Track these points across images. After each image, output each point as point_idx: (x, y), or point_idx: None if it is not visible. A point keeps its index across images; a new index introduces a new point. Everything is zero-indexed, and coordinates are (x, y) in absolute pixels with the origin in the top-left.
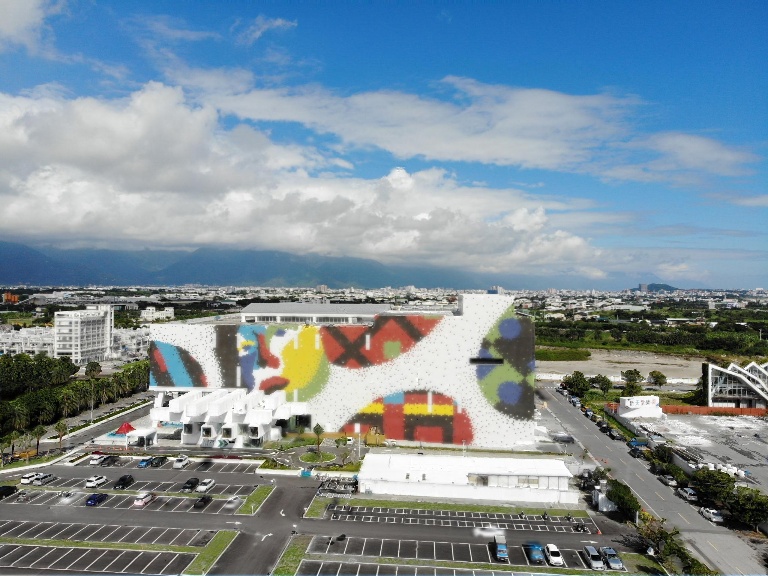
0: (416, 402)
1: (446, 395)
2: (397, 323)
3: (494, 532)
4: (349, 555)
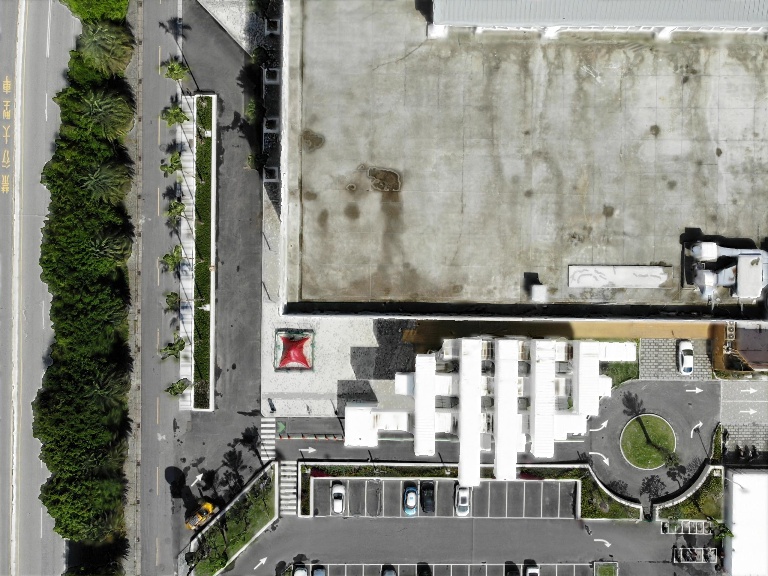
0: None
1: None
2: None
3: None
4: None
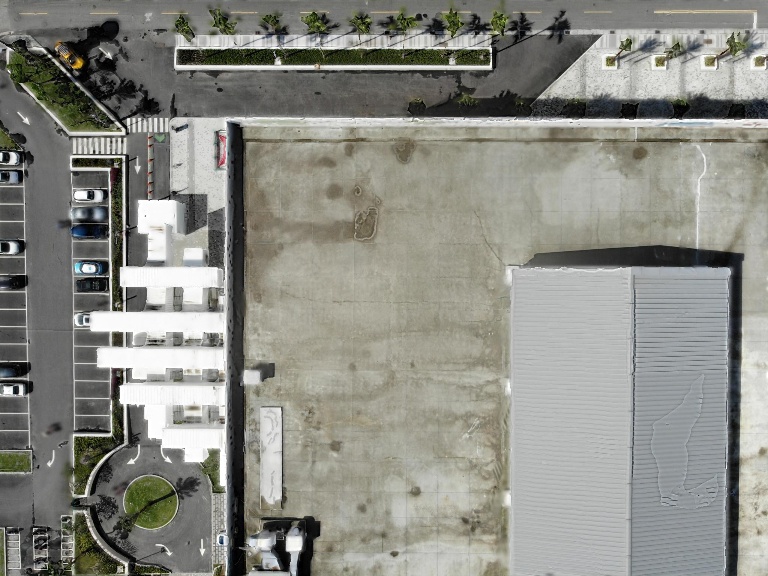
0: None
1: None
2: None
3: None
4: None
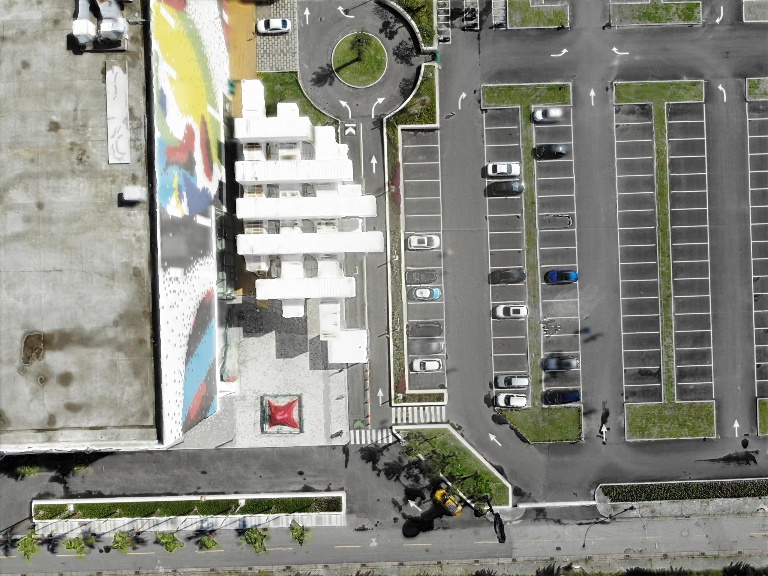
0: None
1: None
2: None
3: None
4: None
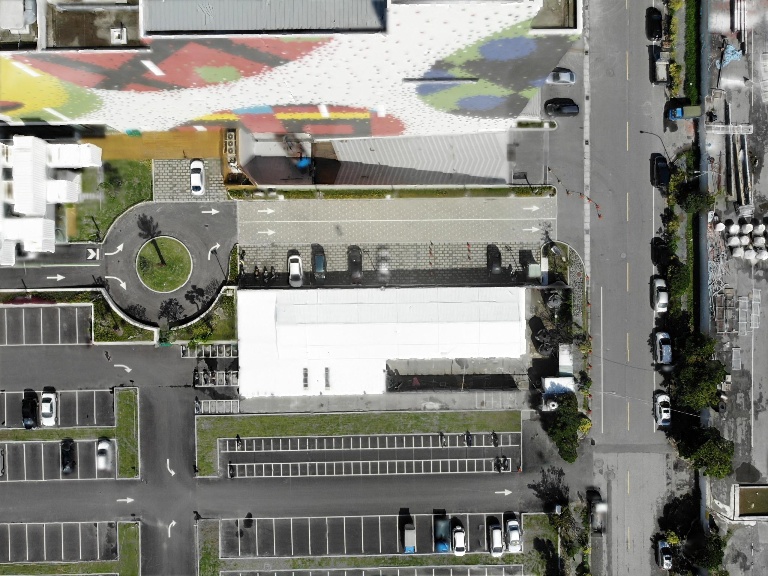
0: (297, 111)
1: (354, 107)
2: (210, 46)
3: (407, 484)
4: (262, 559)
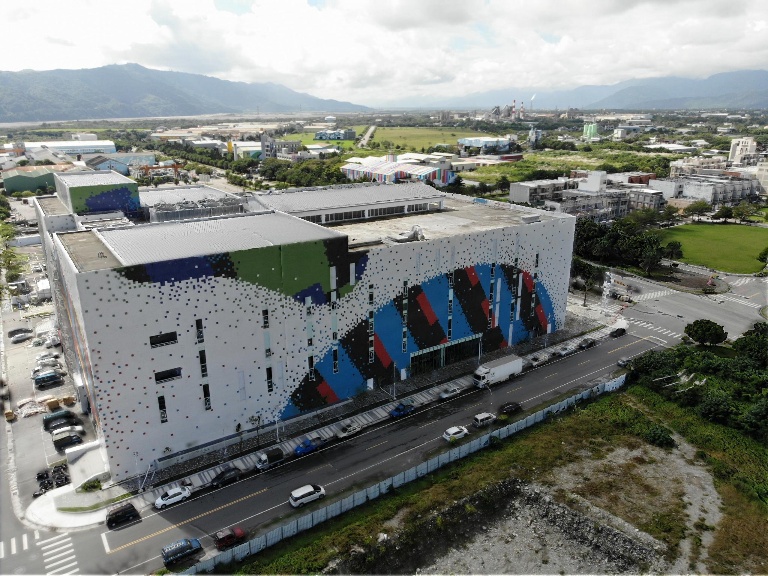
0: None
1: None
2: None
3: None
4: None
